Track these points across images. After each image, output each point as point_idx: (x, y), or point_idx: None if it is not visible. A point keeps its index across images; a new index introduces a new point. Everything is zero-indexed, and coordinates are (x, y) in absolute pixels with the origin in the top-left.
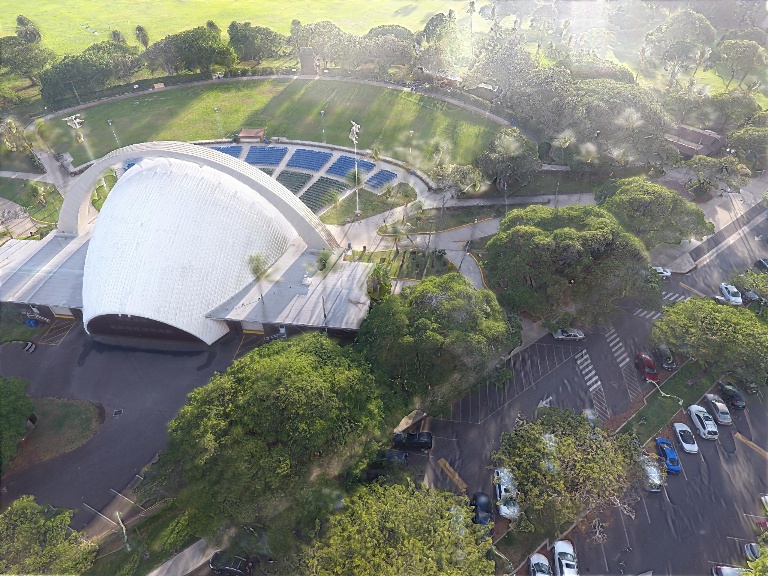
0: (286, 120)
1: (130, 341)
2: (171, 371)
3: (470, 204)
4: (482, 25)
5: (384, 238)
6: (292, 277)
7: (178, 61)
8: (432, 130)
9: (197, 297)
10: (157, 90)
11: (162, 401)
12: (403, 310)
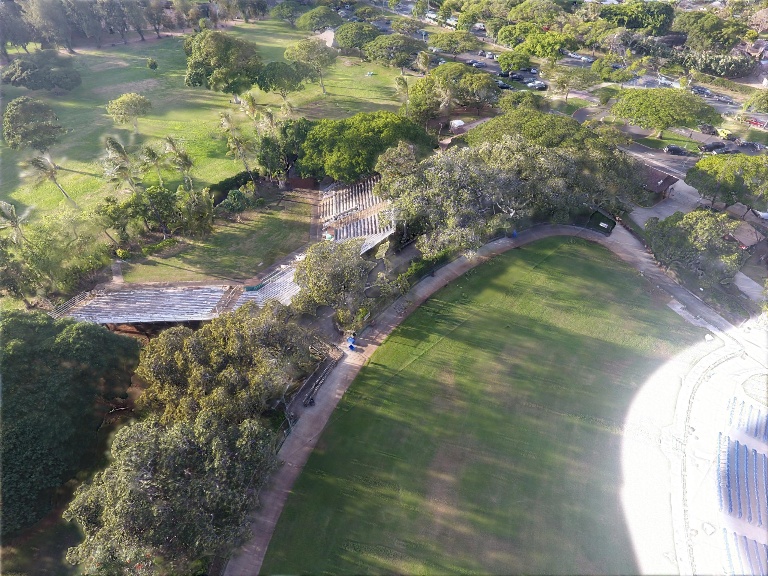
0: None
1: None
2: None
3: None
4: None
5: None
6: None
7: None
8: (551, 332)
9: None
10: None
11: None
12: None
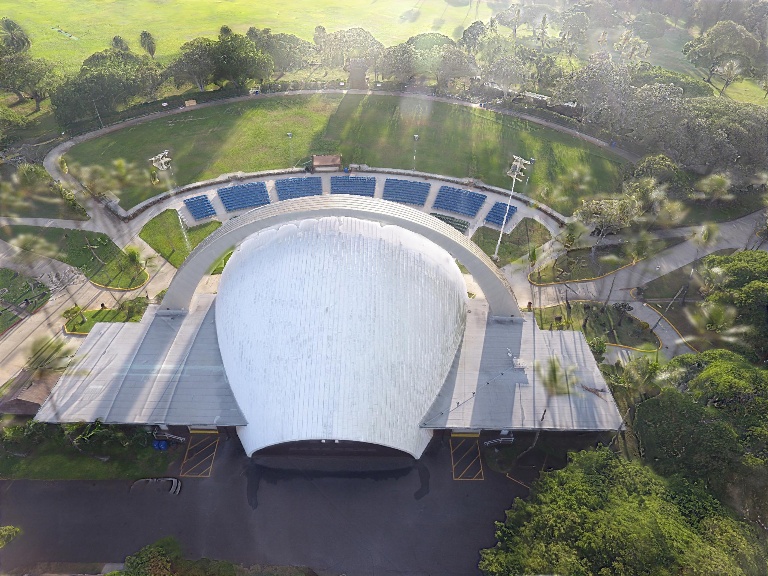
0: (357, 143)
1: (306, 461)
2: (382, 504)
3: (615, 242)
4: None
5: (542, 289)
6: (495, 358)
7: (210, 74)
8: (528, 153)
9: (411, 403)
10: (190, 108)
11: (392, 554)
12: (714, 414)
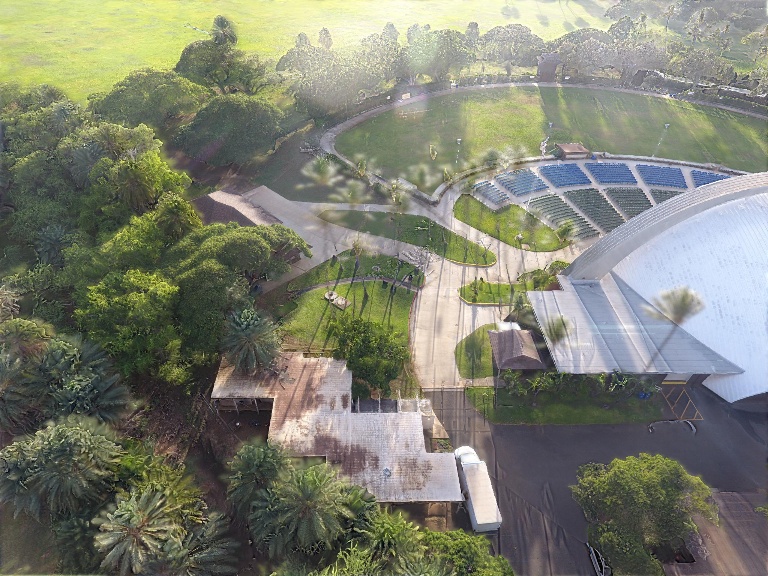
0: (585, 133)
1: None
2: None
3: None
4: (606, 28)
5: None
6: None
7: None
8: (749, 140)
9: None
10: (408, 101)
11: None
12: None
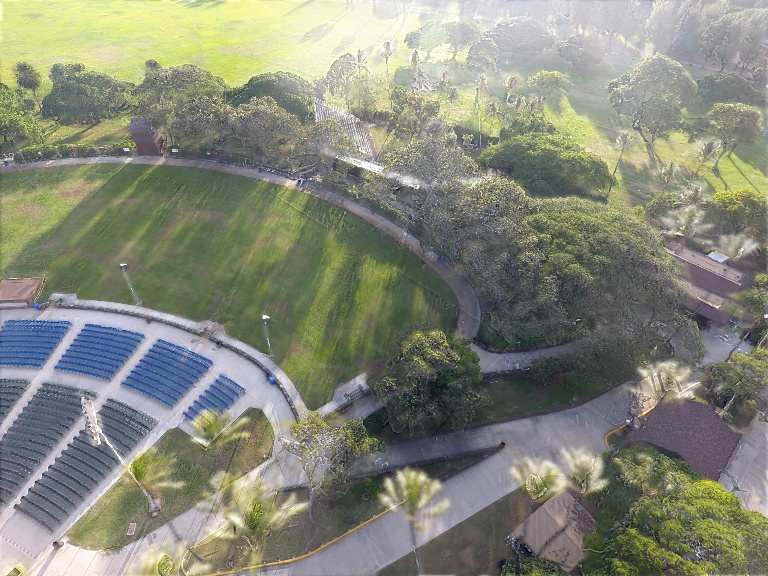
0: (87, 253)
1: None
2: None
3: (366, 466)
4: (409, 55)
5: None
6: None
7: None
8: (318, 273)
9: None
10: None
11: None
12: None
